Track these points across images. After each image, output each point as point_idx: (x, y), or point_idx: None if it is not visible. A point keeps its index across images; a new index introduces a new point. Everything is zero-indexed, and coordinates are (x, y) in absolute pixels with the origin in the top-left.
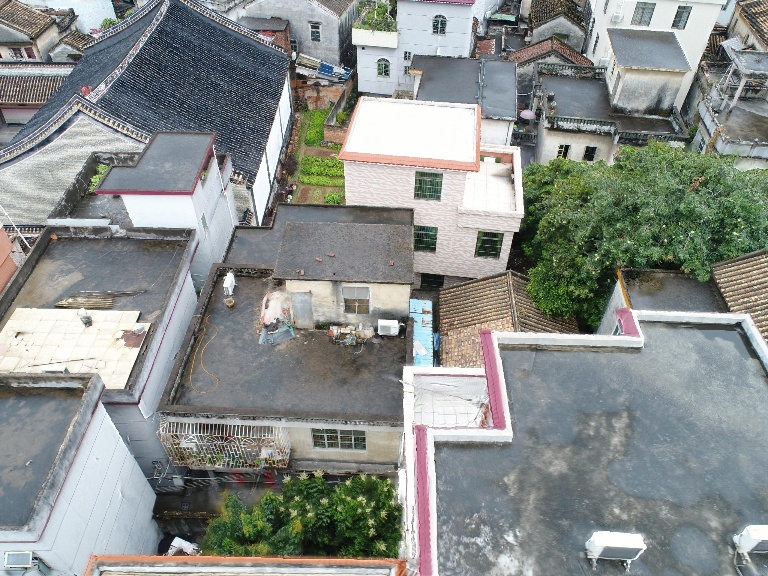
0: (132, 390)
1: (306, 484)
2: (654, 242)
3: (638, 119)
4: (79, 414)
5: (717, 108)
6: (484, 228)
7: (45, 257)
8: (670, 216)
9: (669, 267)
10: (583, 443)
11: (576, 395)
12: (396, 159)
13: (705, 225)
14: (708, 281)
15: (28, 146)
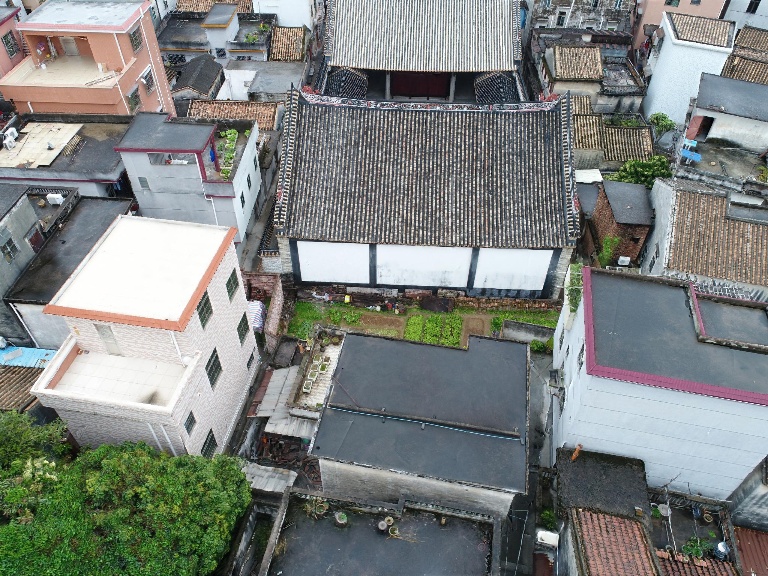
0: None
1: None
2: None
3: None
4: None
5: None
6: None
7: None
8: None
9: None
10: None
11: None
12: None
13: None
14: None
15: None
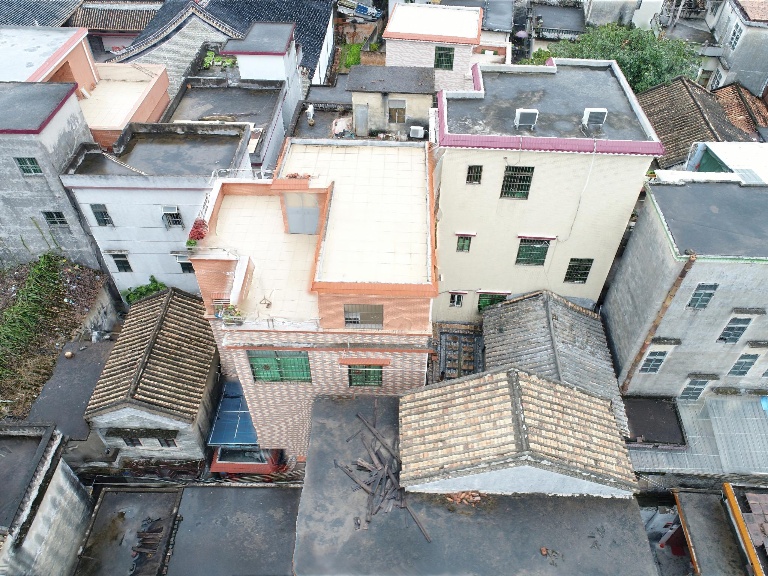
0: (260, 153)
1: None
2: None
3: None
4: (243, 139)
5: (665, 24)
6: None
7: (186, 97)
8: None
9: None
10: (519, 99)
11: (518, 85)
12: (422, 36)
13: (628, 70)
14: None
15: (152, 42)
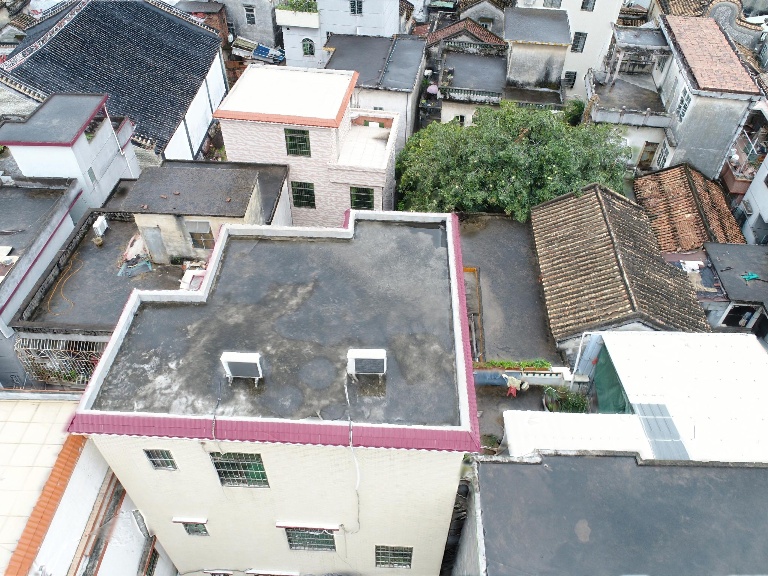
0: None
1: None
2: (481, 187)
3: (529, 91)
4: None
5: (602, 81)
6: (354, 183)
7: None
8: (497, 164)
9: (495, 210)
10: (265, 303)
11: (276, 270)
12: (264, 116)
13: (525, 171)
14: (527, 222)
15: None
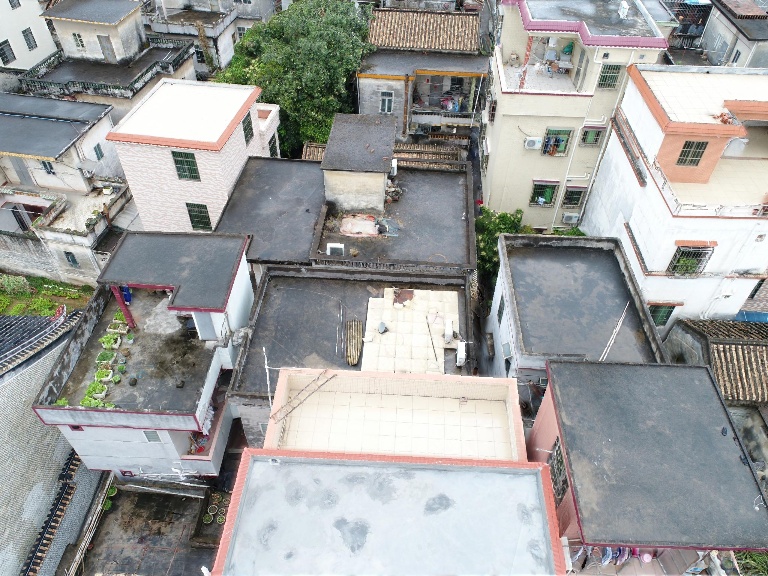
0: (467, 275)
1: (486, 244)
2: None
3: (143, 58)
4: None
5: None
6: None
7: None
8: None
9: None
10: None
11: None
12: (236, 120)
13: None
14: None
15: None
